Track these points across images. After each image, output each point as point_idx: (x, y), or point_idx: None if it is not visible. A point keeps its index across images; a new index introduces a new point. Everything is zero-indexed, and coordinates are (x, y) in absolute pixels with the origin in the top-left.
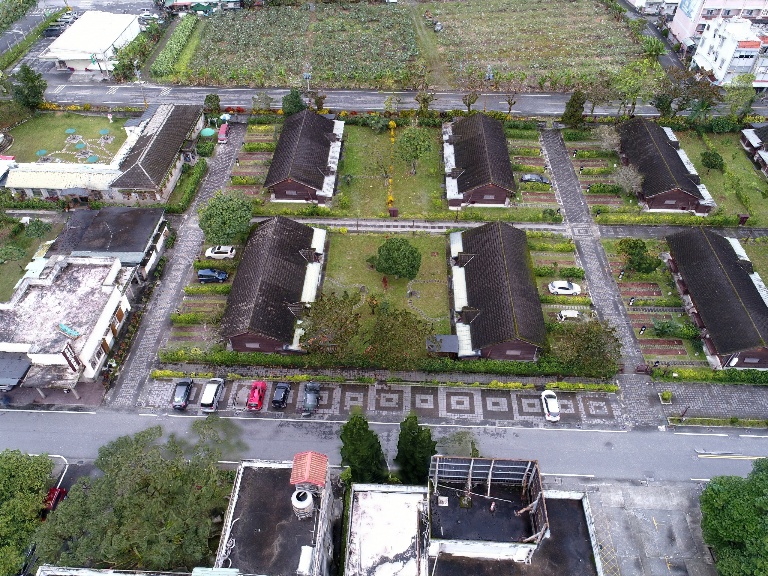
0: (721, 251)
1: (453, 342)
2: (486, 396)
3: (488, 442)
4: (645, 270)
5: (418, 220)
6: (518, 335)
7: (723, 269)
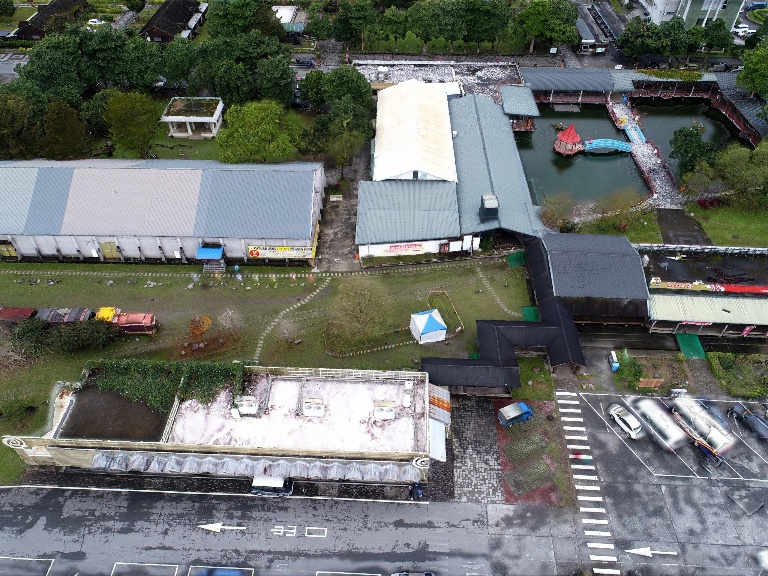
0: (182, 2)
1: (6, 33)
2: (15, 54)
3: (0, 65)
4: (135, 10)
5: (44, 3)
6: (30, 23)
7: (169, 5)
